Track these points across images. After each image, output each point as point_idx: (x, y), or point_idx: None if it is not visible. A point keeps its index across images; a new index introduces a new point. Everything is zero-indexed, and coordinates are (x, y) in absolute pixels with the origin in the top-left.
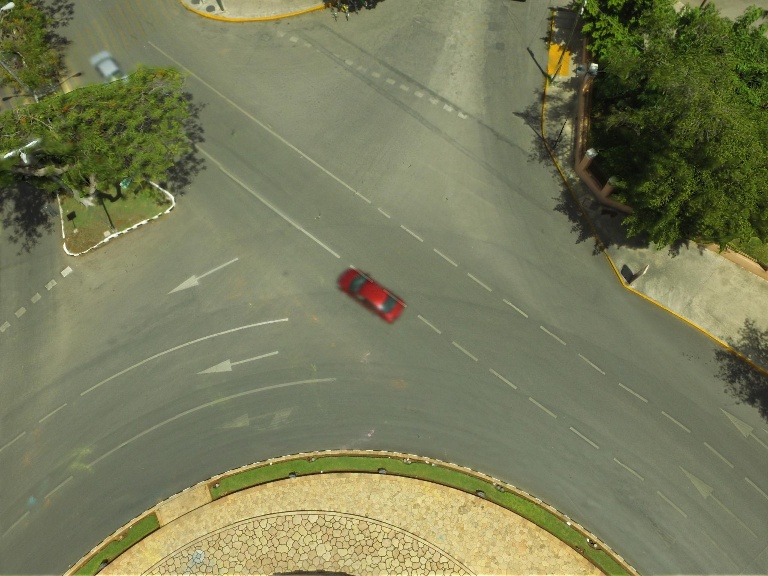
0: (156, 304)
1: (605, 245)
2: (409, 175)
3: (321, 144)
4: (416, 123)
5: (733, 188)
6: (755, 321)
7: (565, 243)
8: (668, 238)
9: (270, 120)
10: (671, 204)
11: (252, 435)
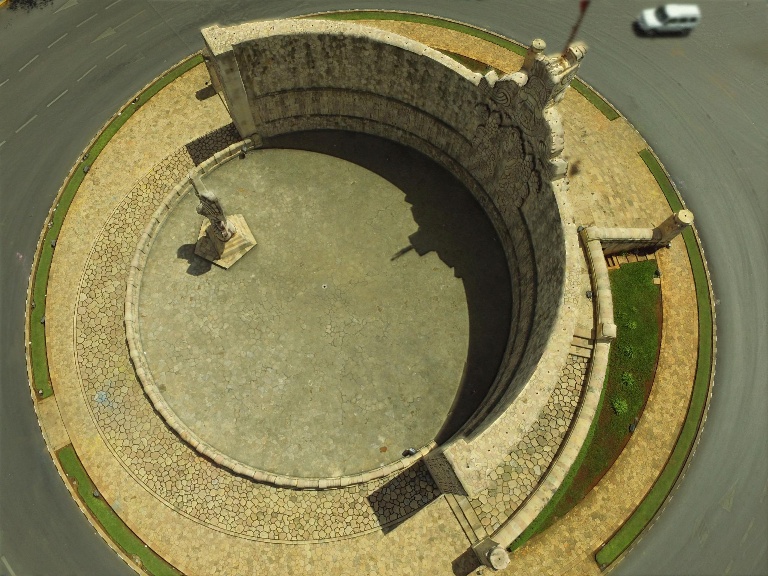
0: None
1: None
2: None
3: None
4: None
5: None
6: None
7: None
8: None
9: None
10: None
11: None
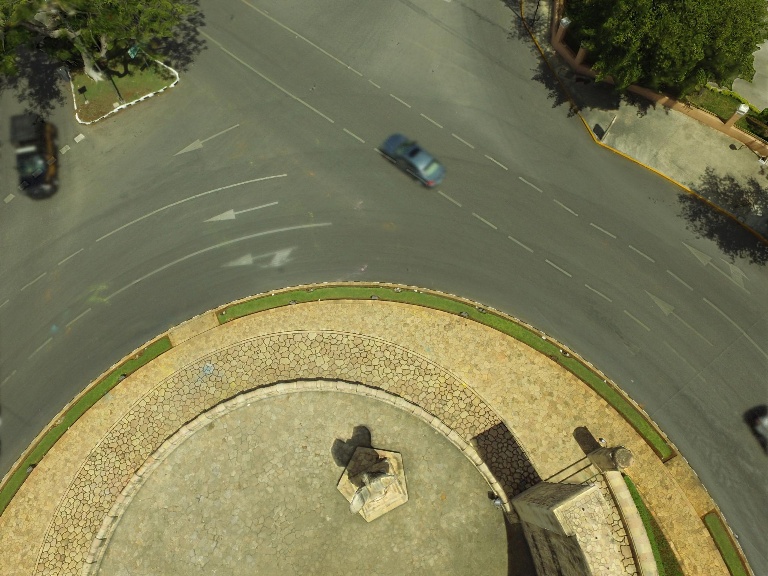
0: (164, 164)
1: (579, 108)
2: (397, 51)
3: (315, 26)
4: (404, 7)
5: (686, 13)
6: (715, 169)
7: (542, 107)
8: (632, 76)
9: (267, 6)
10: (632, 36)
11: (255, 271)
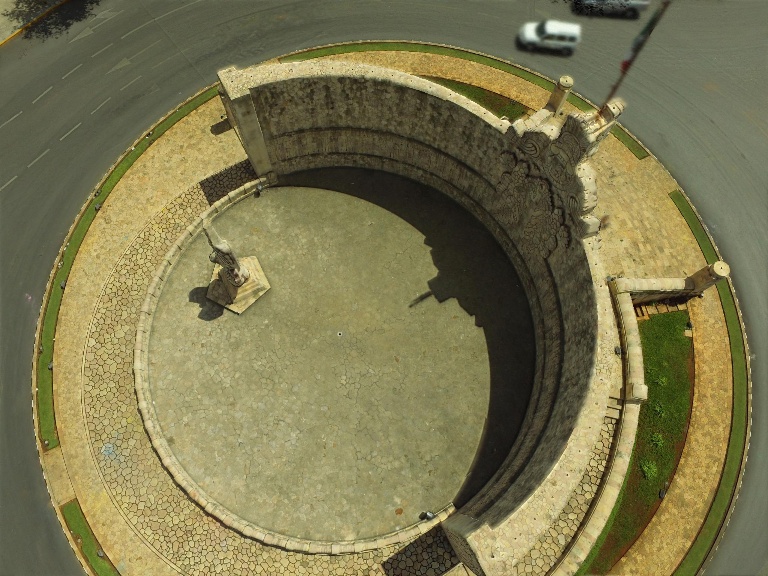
0: None
1: None
2: None
3: None
4: None
5: None
6: (5, 9)
7: None
8: None
9: None
10: None
11: (3, 412)
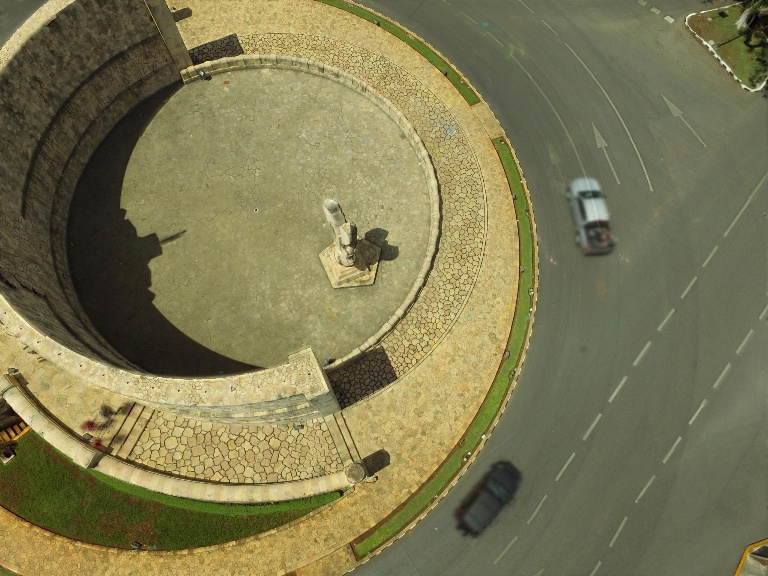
0: (651, 86)
1: None
2: None
3: None
4: None
5: None
6: None
7: None
8: None
9: None
10: None
11: (544, 166)
